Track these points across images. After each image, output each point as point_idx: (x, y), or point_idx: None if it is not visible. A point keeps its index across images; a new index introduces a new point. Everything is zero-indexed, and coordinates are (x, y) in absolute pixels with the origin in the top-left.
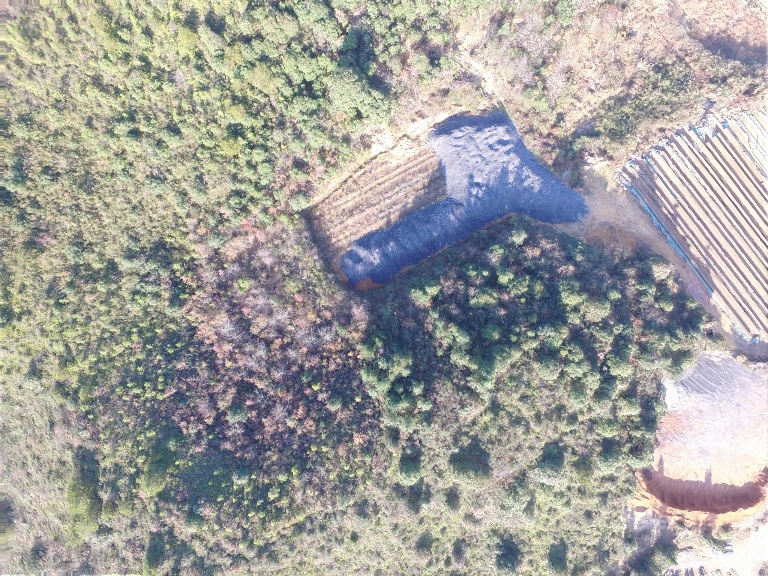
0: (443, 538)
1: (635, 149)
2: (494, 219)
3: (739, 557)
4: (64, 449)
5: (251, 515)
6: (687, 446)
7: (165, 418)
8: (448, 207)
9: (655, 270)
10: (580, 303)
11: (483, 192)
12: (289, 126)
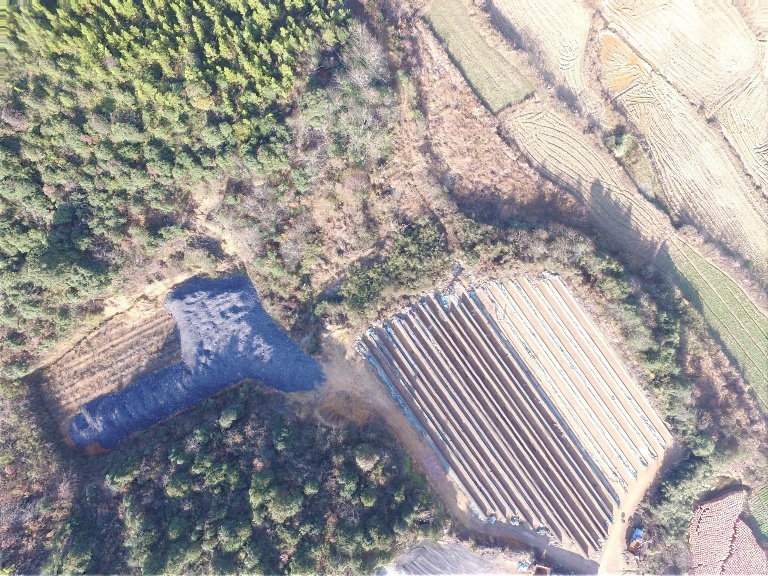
0: None
1: (375, 318)
2: (228, 385)
3: None
4: None
5: None
6: None
7: None
8: (178, 373)
9: (358, 462)
10: (267, 501)
11: (211, 361)
12: (2, 298)
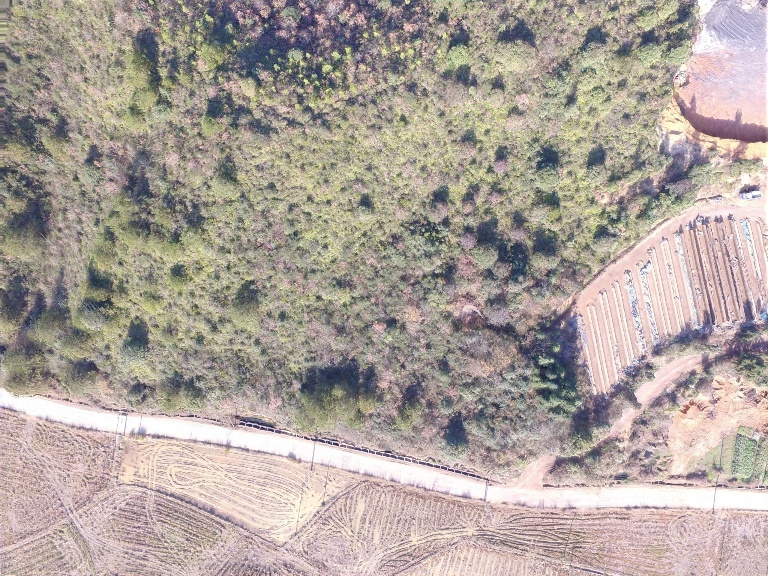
0: (486, 141)
1: None
2: None
3: (767, 206)
4: (124, 37)
5: (307, 81)
6: (719, 86)
7: (222, 11)
8: None
9: None
10: None
11: None
12: None
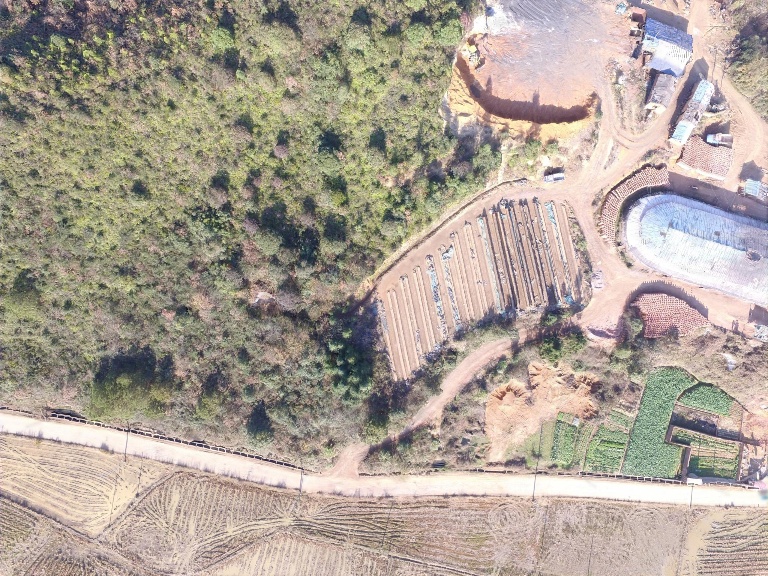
0: (265, 125)
1: None
2: None
3: (572, 189)
4: None
5: (64, 66)
6: (515, 68)
7: None
8: None
9: None
10: None
11: None
12: None
